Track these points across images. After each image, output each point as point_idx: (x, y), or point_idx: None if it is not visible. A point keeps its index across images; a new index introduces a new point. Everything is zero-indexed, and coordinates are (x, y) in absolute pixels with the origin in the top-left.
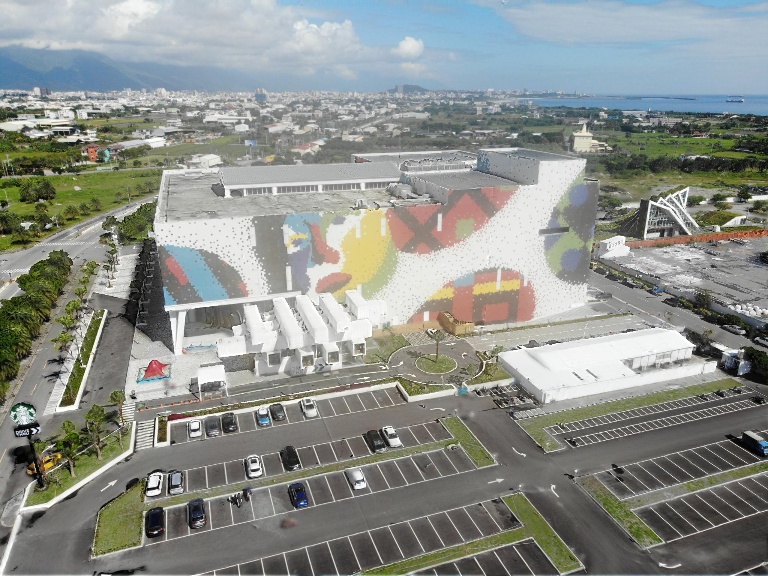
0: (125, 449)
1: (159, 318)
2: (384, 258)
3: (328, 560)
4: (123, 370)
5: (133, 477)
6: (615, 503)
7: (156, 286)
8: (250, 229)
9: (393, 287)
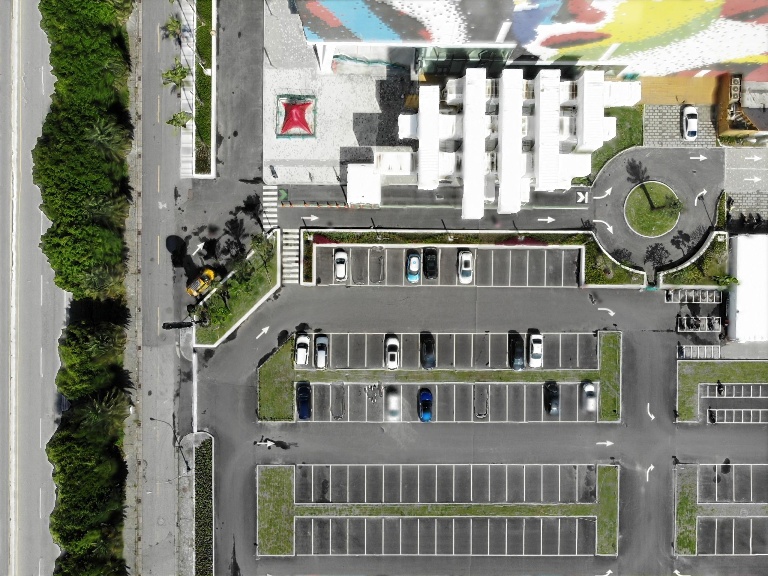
0: (273, 284)
1: None
2: (685, 23)
3: (432, 484)
4: (257, 92)
5: (283, 327)
6: (690, 505)
7: None
8: None
9: (673, 48)
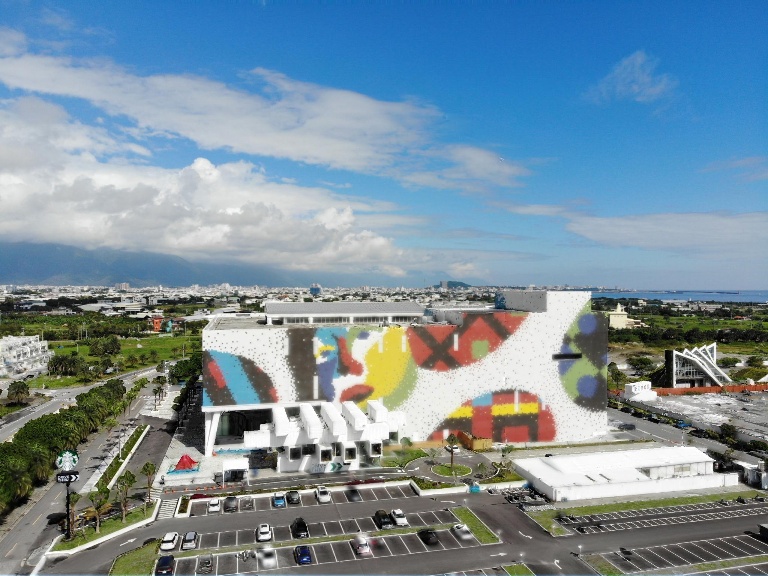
0: (148, 516)
1: (195, 432)
2: (404, 373)
3: None
4: (156, 465)
5: (151, 537)
6: (619, 575)
7: (197, 411)
8: (284, 340)
9: (413, 402)
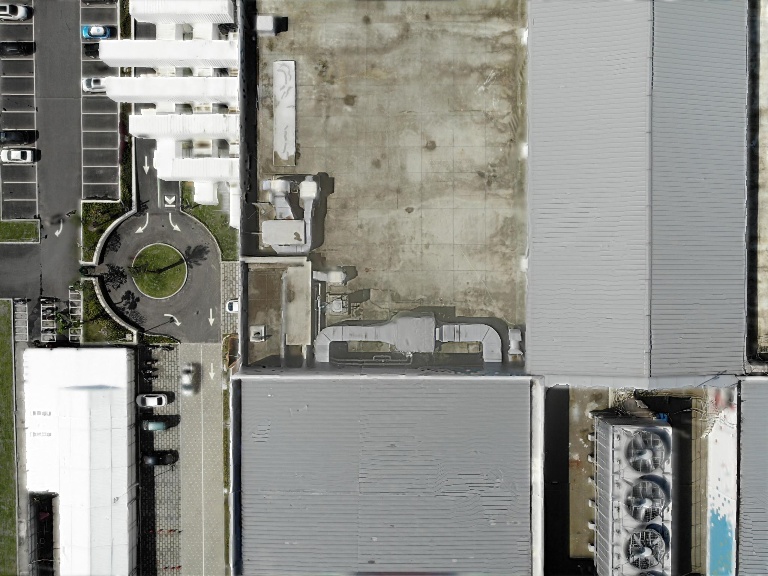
0: None
1: None
2: None
3: None
4: None
5: None
6: None
7: None
8: None
9: None
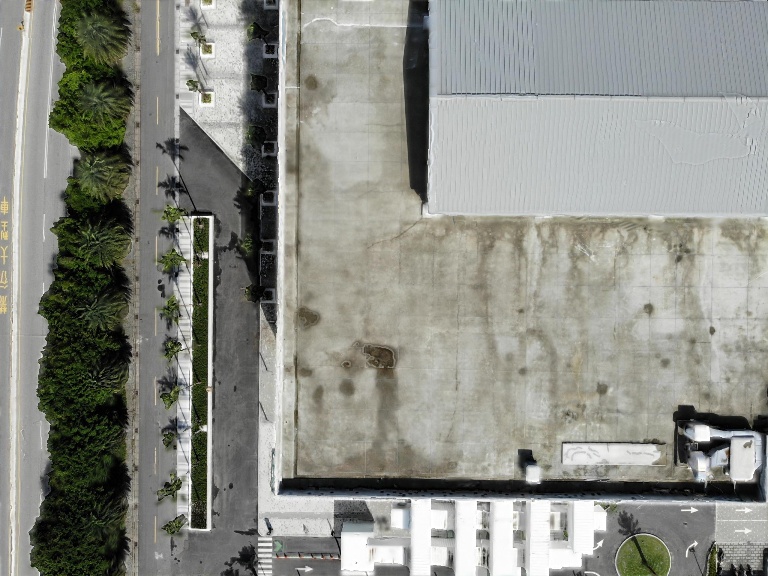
0: None
1: None
2: None
3: None
4: (252, 445)
5: None
6: None
7: None
8: None
9: None
